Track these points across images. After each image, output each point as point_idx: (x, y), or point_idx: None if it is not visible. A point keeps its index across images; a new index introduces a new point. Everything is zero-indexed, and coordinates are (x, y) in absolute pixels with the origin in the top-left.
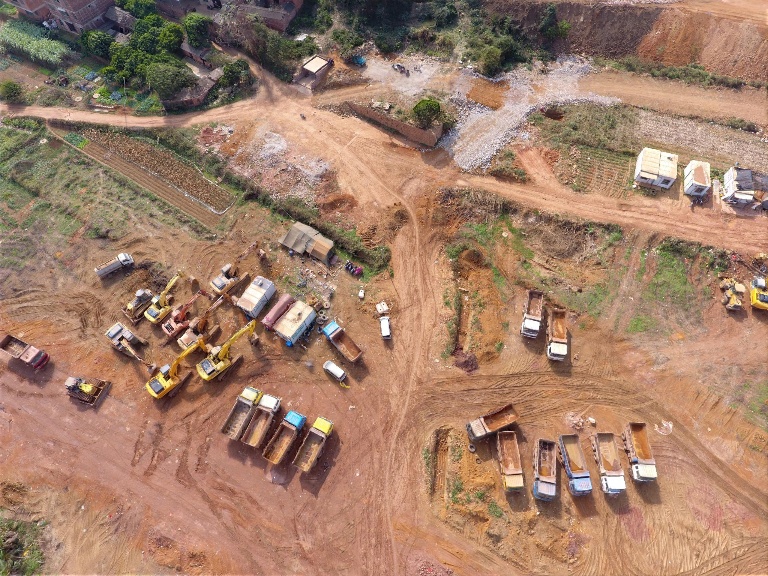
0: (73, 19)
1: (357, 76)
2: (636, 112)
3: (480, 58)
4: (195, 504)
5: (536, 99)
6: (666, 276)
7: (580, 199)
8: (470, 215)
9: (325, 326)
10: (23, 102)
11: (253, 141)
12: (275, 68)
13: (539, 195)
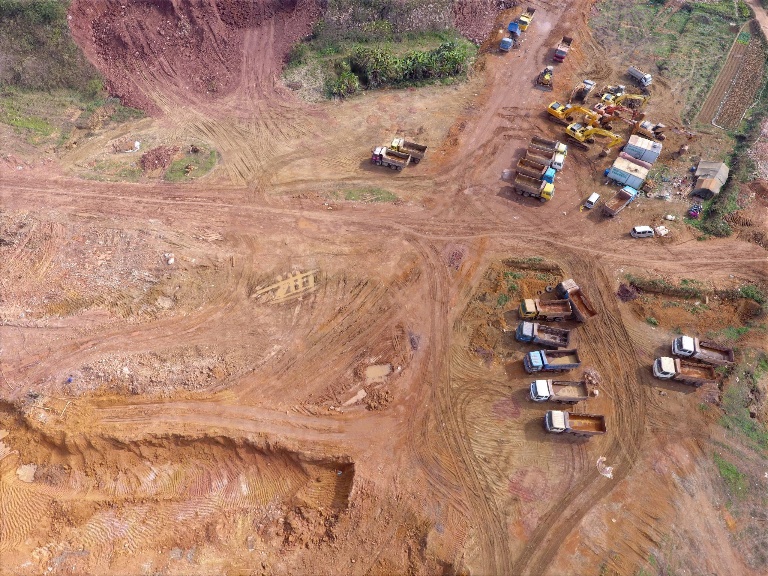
0: None
1: None
2: None
3: None
4: (485, 137)
5: None
6: None
7: None
8: None
9: None
10: (765, 4)
11: None
12: None
13: None
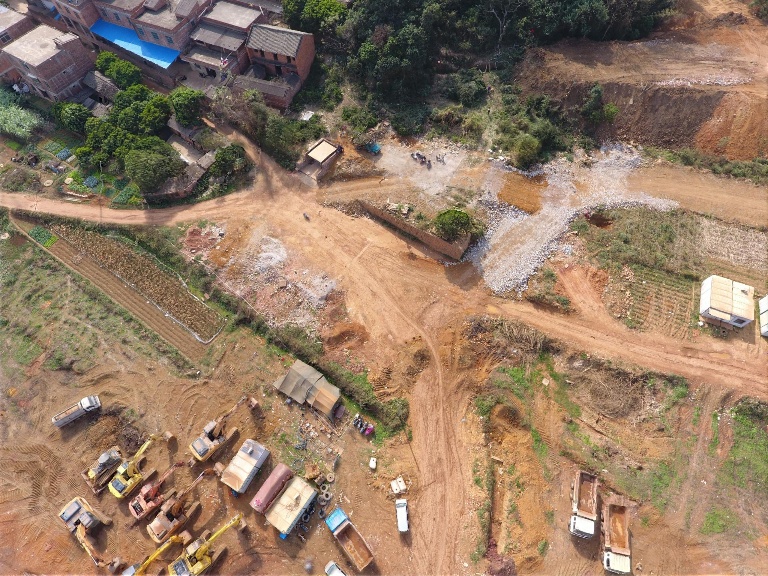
0: (45, 87)
1: (370, 167)
2: (697, 221)
3: (513, 147)
4: None
5: (579, 201)
6: (745, 450)
7: (636, 339)
8: (504, 355)
9: (328, 507)
10: None
11: (247, 248)
12: (275, 152)
13: (586, 331)
